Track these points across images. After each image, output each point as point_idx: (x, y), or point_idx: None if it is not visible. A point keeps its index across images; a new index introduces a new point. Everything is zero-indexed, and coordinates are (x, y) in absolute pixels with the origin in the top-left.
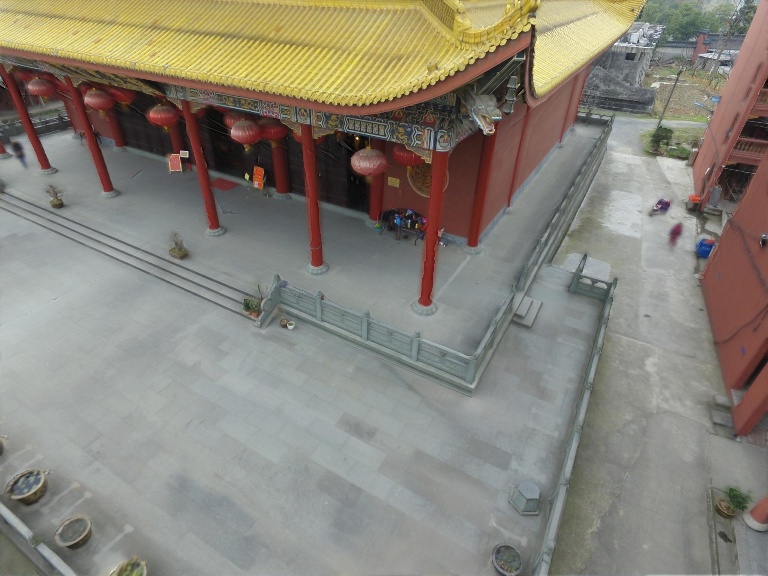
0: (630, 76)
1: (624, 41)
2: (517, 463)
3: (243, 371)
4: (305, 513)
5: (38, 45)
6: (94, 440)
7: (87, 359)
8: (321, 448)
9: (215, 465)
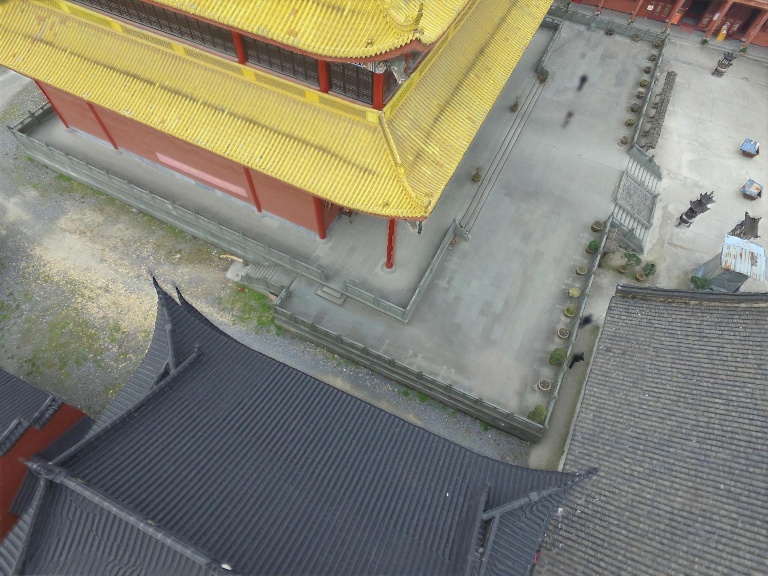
0: None
1: None
2: (581, 29)
3: (572, 81)
4: (613, 63)
5: (518, 56)
6: (613, 106)
7: (584, 121)
8: (593, 62)
9: (608, 80)
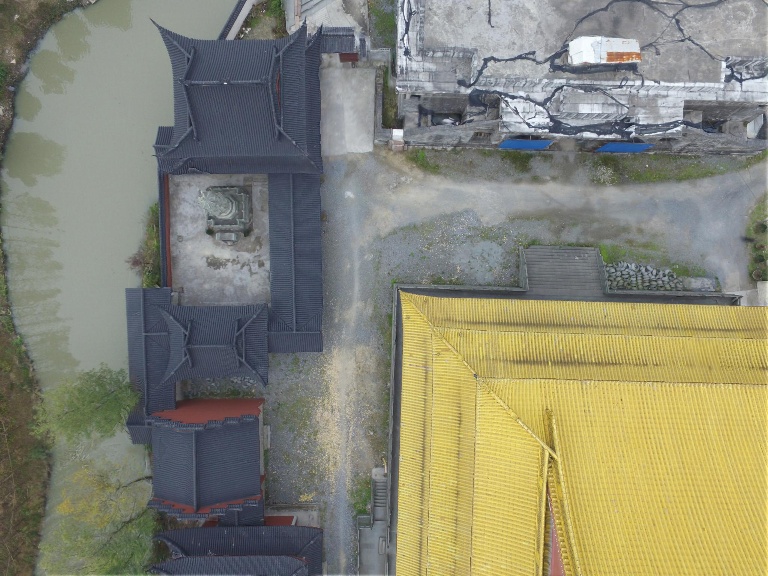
0: (751, 119)
1: (759, 66)
2: None
3: None
4: None
5: None
6: None
7: None
8: None
9: None
